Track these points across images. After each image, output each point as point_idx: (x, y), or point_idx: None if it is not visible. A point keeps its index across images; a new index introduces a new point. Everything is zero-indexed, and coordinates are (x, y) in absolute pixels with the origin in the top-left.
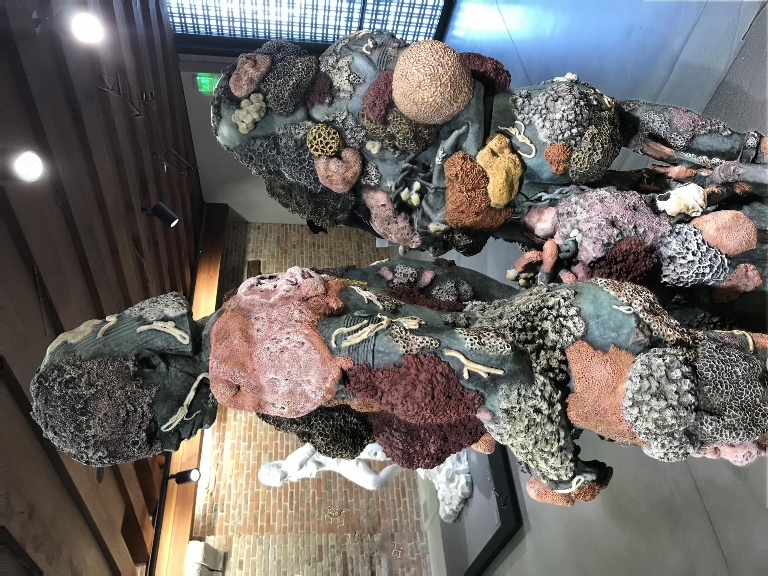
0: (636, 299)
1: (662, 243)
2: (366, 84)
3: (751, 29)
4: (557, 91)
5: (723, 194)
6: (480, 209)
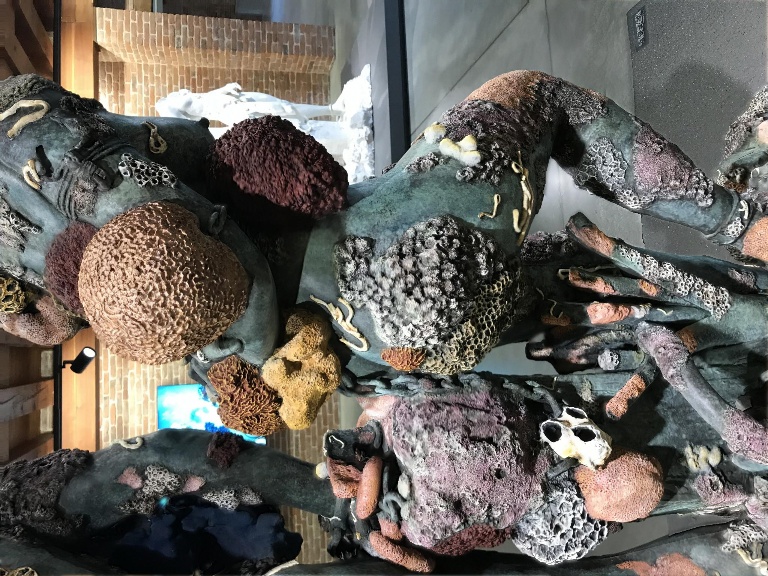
0: None
1: (524, 519)
2: (45, 235)
3: None
4: (419, 256)
5: (647, 386)
6: (268, 431)
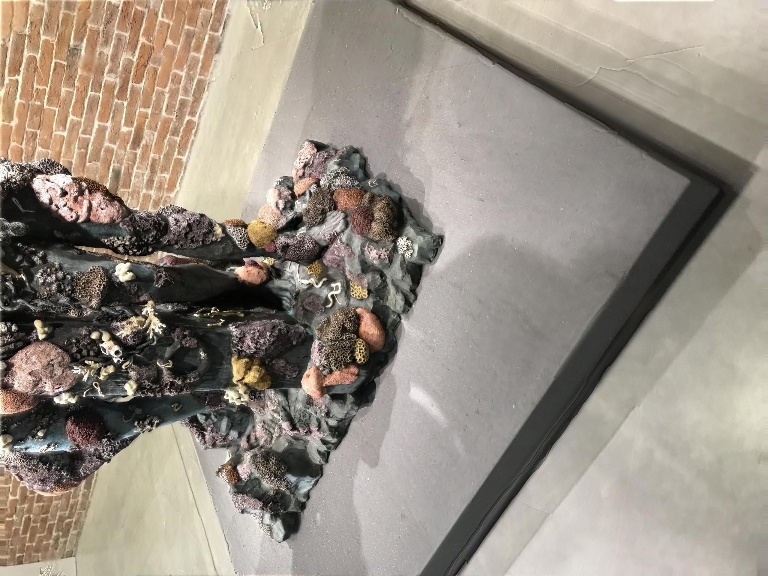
0: None
1: None
2: None
3: (232, 560)
4: None
5: None
6: None
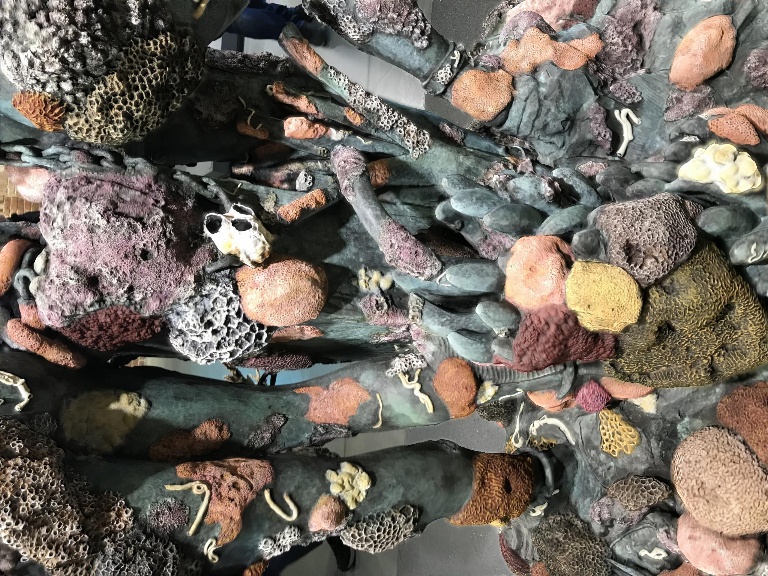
0: (2, 520)
1: (173, 310)
2: None
3: None
4: None
5: (329, 202)
6: None
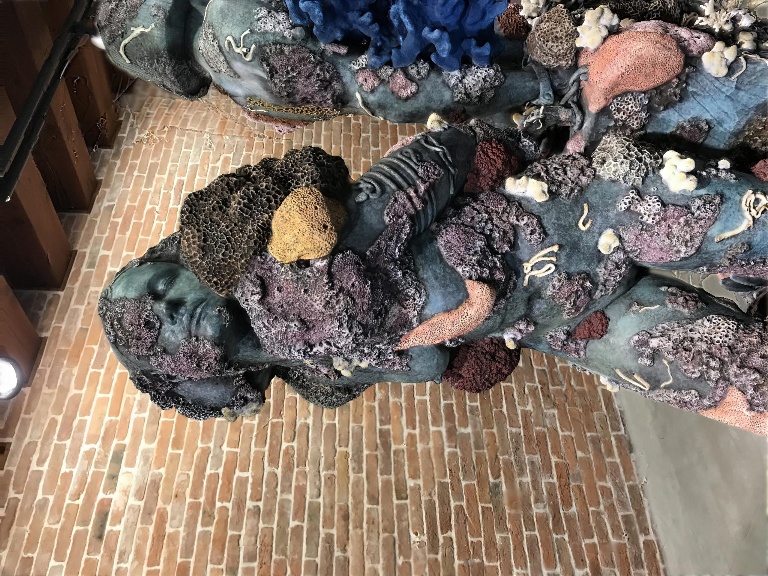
0: None
1: None
2: None
3: None
4: None
5: None
6: None
